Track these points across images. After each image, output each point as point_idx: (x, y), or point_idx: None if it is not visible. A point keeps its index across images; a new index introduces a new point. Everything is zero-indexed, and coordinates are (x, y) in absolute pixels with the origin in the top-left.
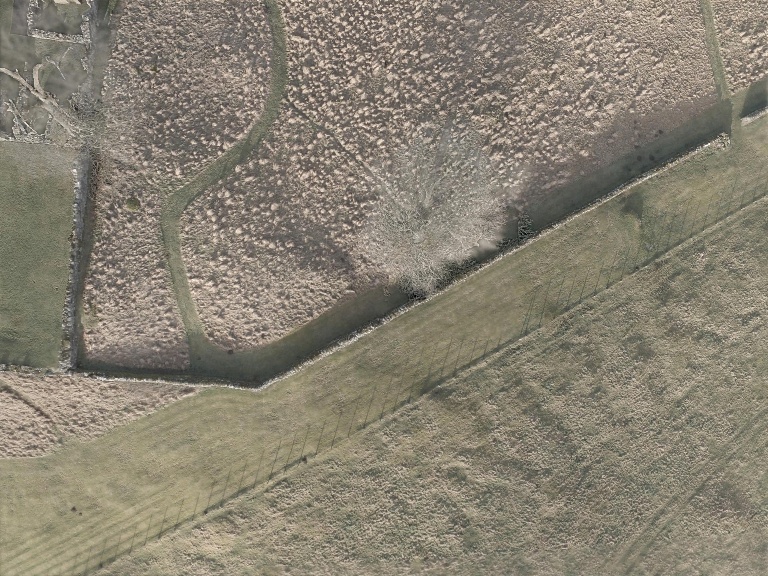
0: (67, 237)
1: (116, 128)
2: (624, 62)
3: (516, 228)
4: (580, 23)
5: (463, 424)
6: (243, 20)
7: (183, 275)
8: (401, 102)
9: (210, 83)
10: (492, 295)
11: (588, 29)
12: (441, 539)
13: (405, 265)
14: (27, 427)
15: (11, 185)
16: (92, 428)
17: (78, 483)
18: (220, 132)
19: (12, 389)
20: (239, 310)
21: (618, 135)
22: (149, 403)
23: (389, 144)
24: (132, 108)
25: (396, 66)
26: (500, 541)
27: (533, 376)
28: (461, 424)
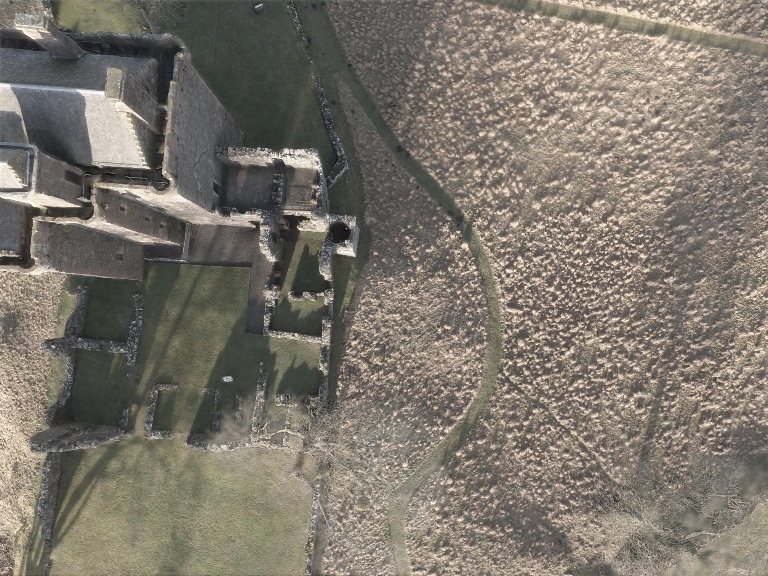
0: (303, 546)
1: (349, 427)
2: None
3: (726, 497)
4: None
5: None
6: (462, 296)
7: (406, 567)
8: (614, 372)
9: (432, 365)
10: (704, 569)
11: None
12: None
13: (621, 544)
14: None
15: (244, 489)
16: None
17: None
18: (441, 414)
19: None
20: None
21: None
22: None
23: (603, 416)
24: (363, 404)
25: (608, 334)
26: None
27: None
28: None
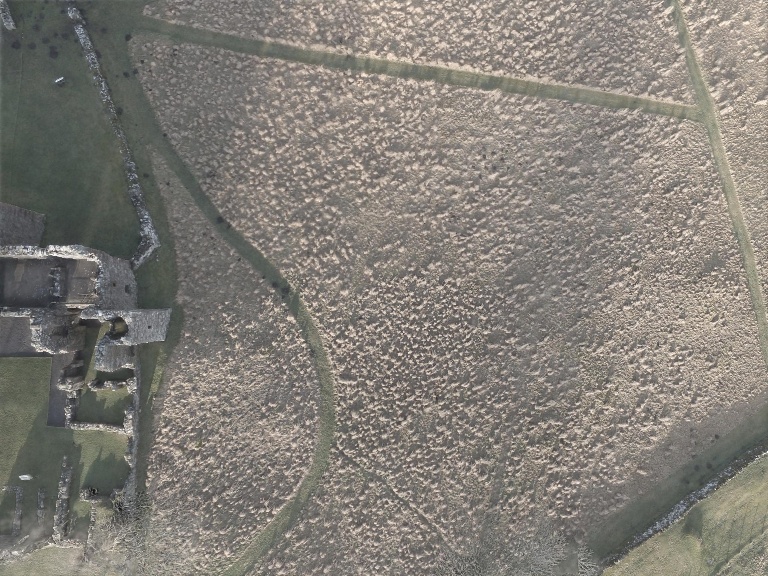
0: None
1: (162, 519)
2: (678, 370)
3: (576, 561)
4: (633, 335)
5: None
6: (289, 371)
7: None
8: (454, 439)
9: (257, 445)
10: None
11: (641, 340)
12: None
13: None
14: None
15: None
16: None
17: None
18: (268, 495)
19: None
20: None
21: (675, 446)
22: None
23: (443, 486)
24: (178, 493)
25: (448, 401)
26: None
27: None
28: None
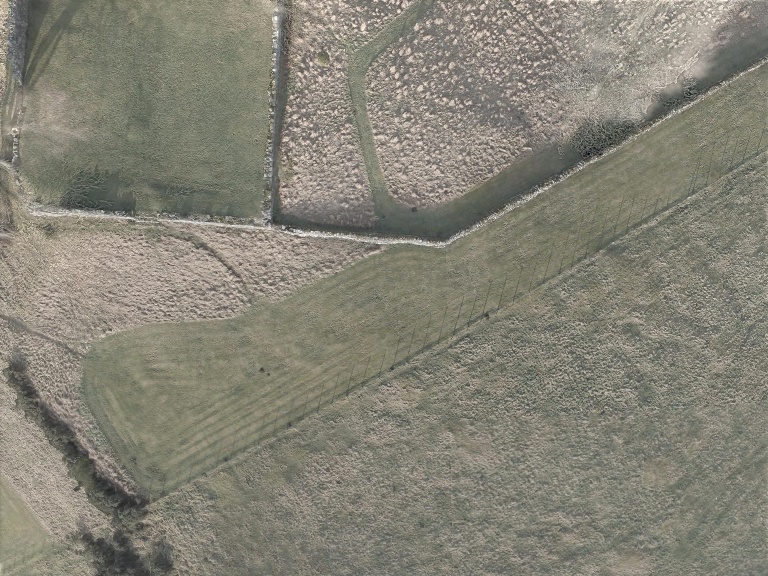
0: (265, 88)
1: None
2: None
3: (682, 88)
4: None
5: (636, 281)
6: None
7: (369, 132)
8: None
9: None
10: (661, 154)
11: None
12: (617, 393)
13: (579, 123)
14: (218, 287)
15: (207, 39)
16: (281, 287)
17: (266, 344)
18: None
19: (208, 246)
20: (422, 167)
21: None
22: (336, 261)
23: (558, 4)
24: None
25: None
26: (673, 396)
27: (700, 235)
28: (634, 281)
